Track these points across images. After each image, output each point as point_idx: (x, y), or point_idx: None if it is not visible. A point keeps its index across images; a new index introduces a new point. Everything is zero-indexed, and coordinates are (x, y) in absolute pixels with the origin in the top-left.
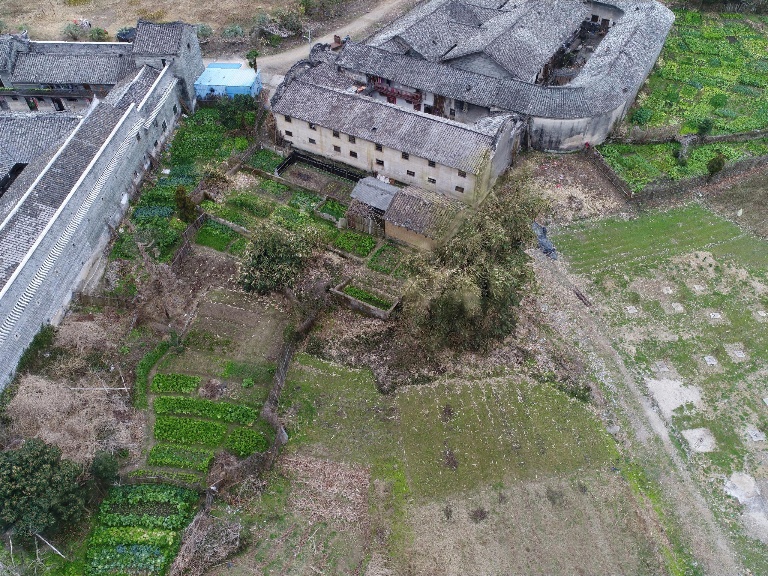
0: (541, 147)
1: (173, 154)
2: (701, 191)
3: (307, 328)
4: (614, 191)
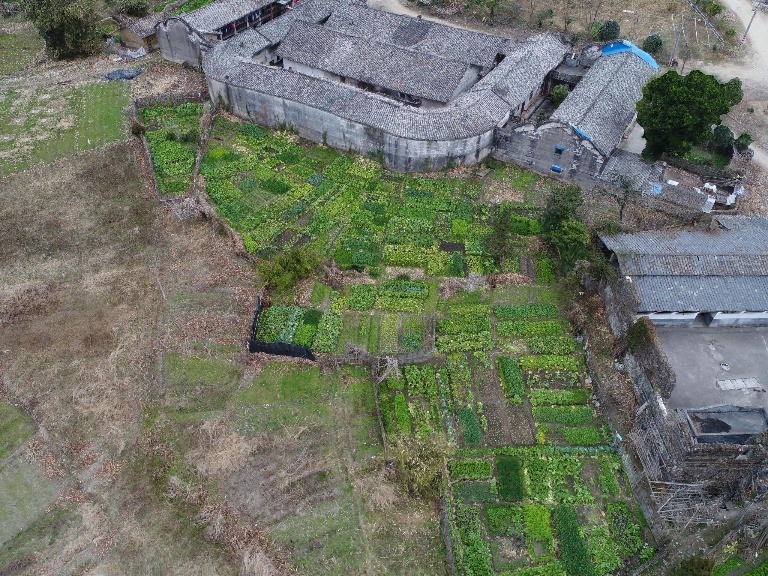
0: None
1: None
2: (135, 141)
3: None
4: None
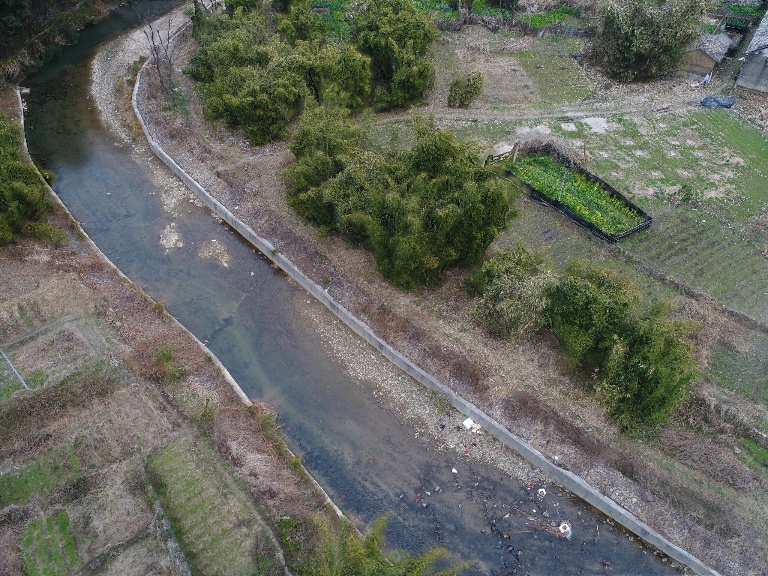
0: None
1: None
2: None
3: None
4: None
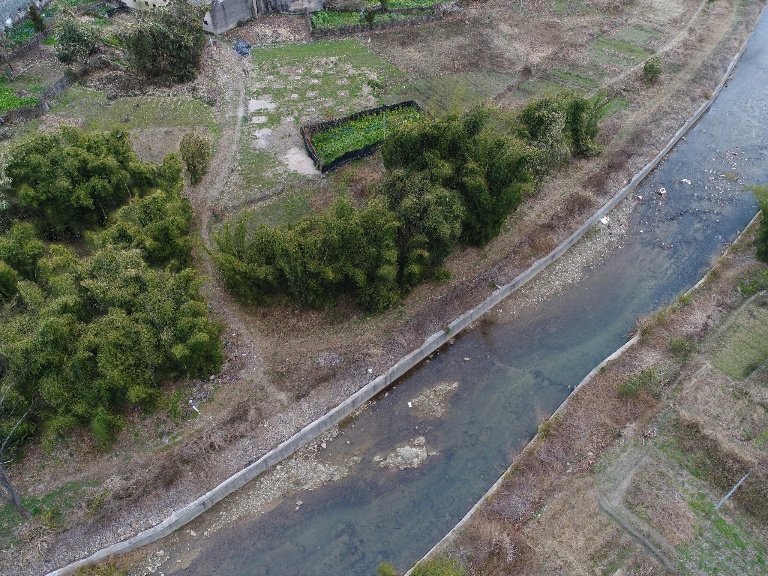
0: (278, 9)
1: (52, 7)
2: (362, 34)
3: (82, 74)
4: (308, 32)
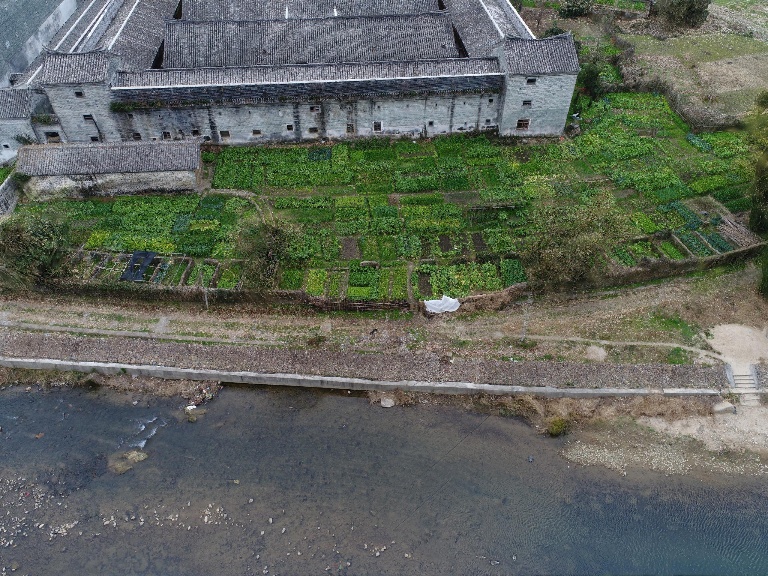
0: None
1: None
2: None
3: None
4: None
